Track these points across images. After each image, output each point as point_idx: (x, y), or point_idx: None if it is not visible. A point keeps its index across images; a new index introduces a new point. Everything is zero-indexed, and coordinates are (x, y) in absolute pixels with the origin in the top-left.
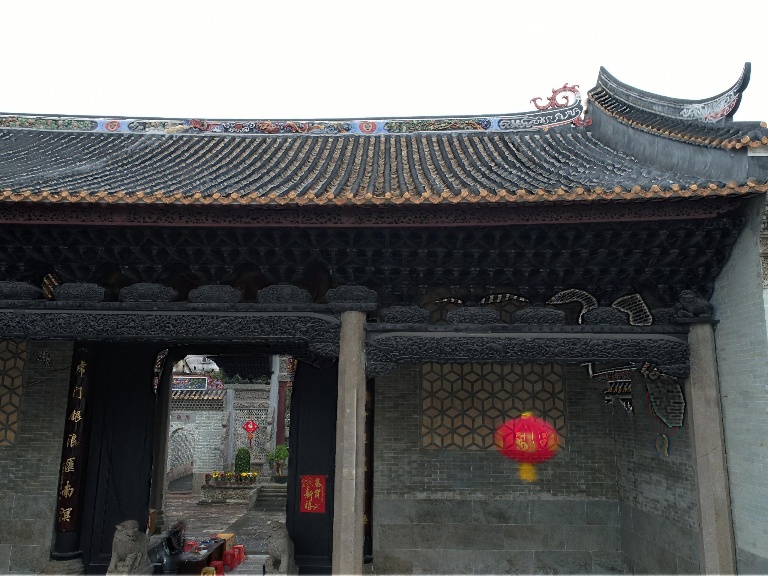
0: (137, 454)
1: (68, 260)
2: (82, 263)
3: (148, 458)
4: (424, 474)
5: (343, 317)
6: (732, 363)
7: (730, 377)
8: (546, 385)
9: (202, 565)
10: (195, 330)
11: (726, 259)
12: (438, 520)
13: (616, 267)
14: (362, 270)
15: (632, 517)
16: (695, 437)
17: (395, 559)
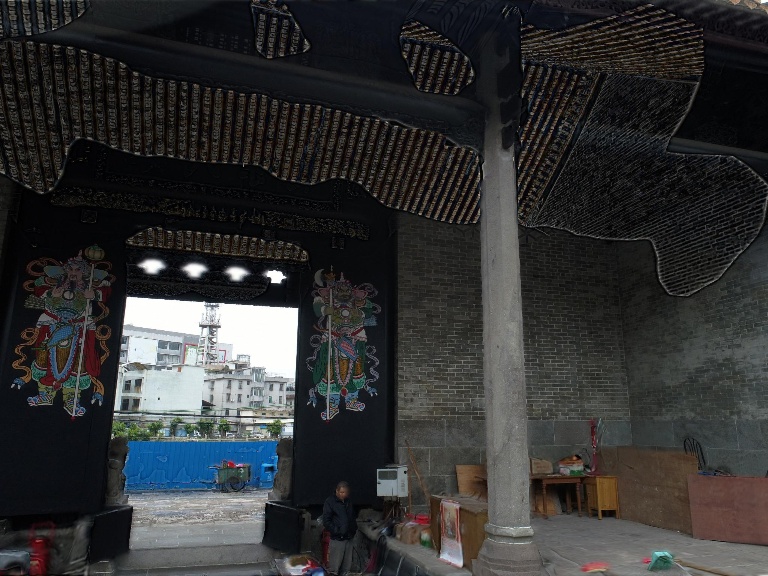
0: None
1: (257, 267)
2: (251, 267)
3: None
4: None
5: None
6: None
7: None
8: None
9: None
10: None
11: None
12: None
13: None
14: None
15: None
16: None
17: None
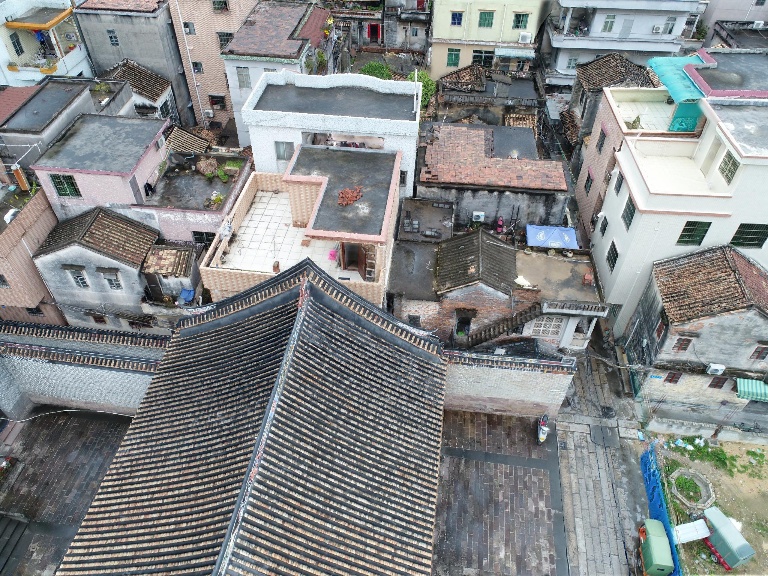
0: None
1: None
2: None
3: None
4: None
5: None
6: None
7: None
8: None
9: None
10: None
11: None
12: None
13: None
14: None
15: None
16: None
17: None
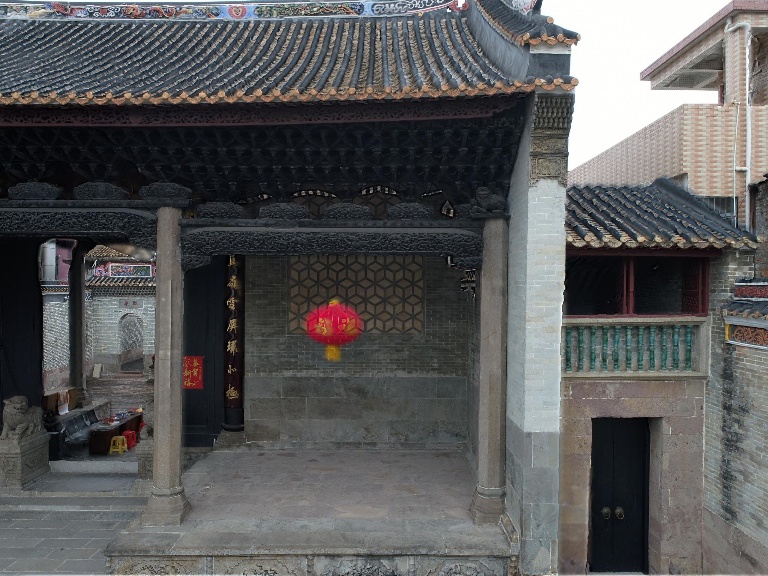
0: (27, 338)
1: None
2: None
3: (37, 342)
4: (291, 355)
5: (159, 213)
6: (513, 256)
7: (512, 268)
8: (407, 274)
9: (112, 434)
10: (18, 226)
11: (513, 157)
12: (303, 395)
13: (411, 165)
14: (170, 168)
15: (471, 391)
16: (481, 322)
17: (264, 428)
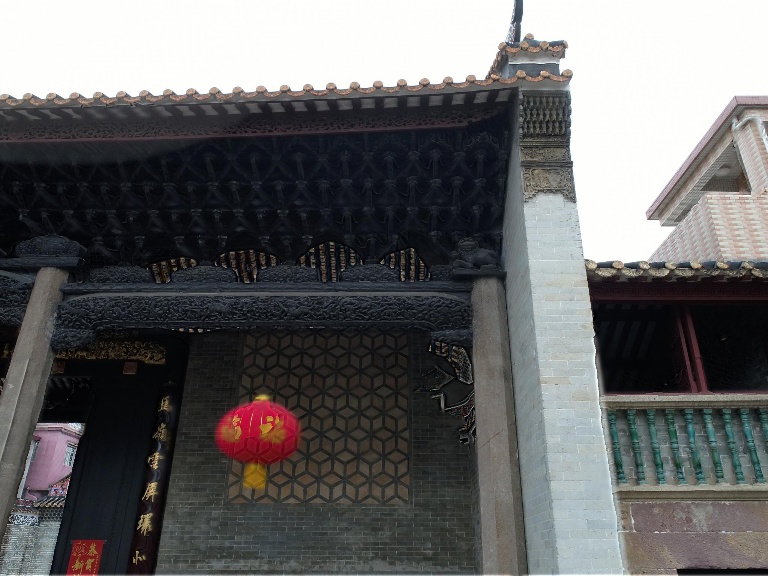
0: None
1: None
2: None
3: None
4: (225, 536)
5: (38, 276)
6: (515, 316)
7: (515, 336)
8: (387, 422)
9: None
10: None
11: (502, 190)
12: None
13: (369, 205)
14: (61, 215)
15: None
16: (476, 421)
17: None
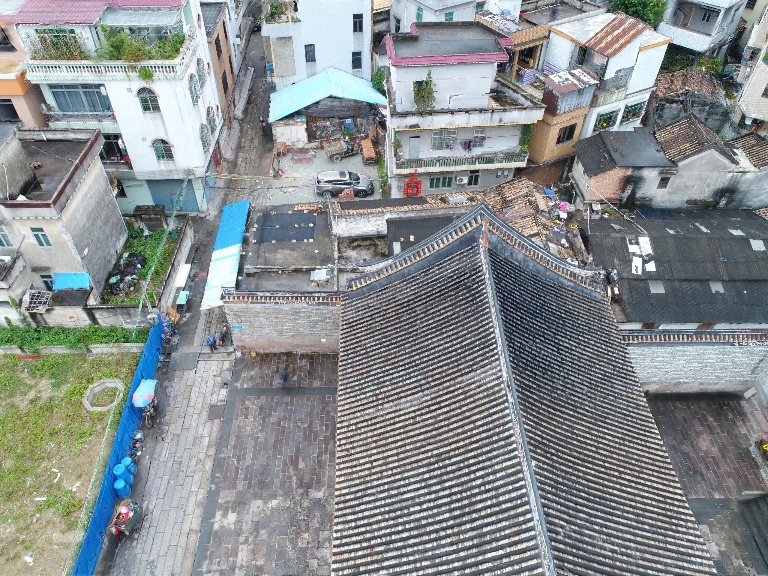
0: None
1: None
2: None
3: None
4: None
5: None
6: None
7: None
8: None
9: None
10: None
11: None
12: None
13: None
14: None
15: None
16: None
17: None
